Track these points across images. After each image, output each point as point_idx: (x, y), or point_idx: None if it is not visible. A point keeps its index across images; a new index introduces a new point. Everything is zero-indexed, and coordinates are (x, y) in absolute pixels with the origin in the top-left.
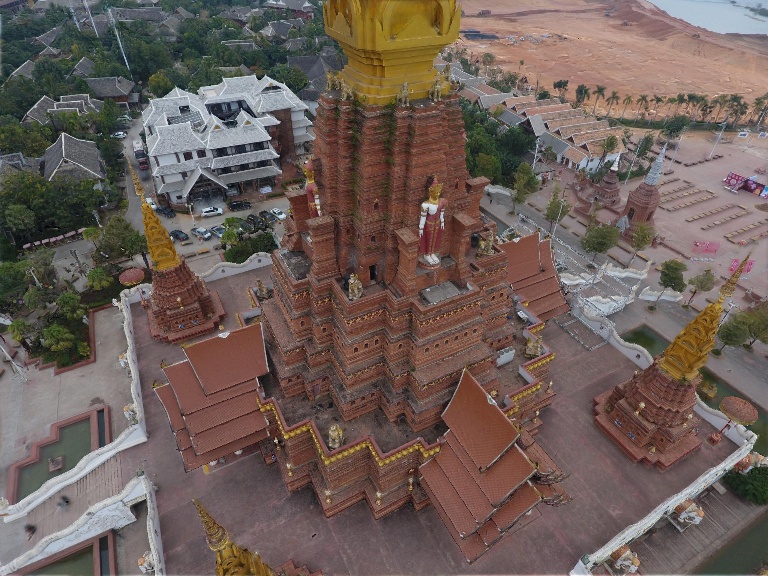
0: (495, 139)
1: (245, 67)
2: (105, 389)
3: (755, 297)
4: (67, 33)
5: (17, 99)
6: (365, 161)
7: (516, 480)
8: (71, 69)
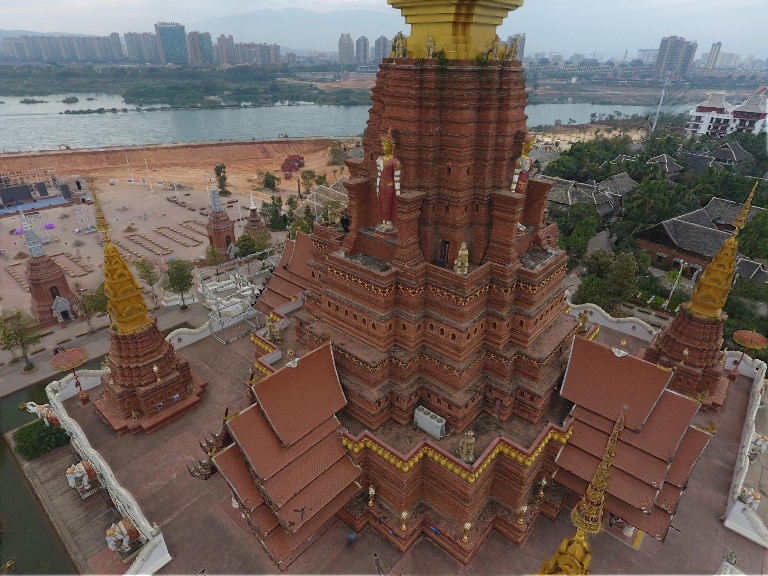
0: None
1: None
2: None
3: None
4: None
5: None
6: None
7: None
8: None
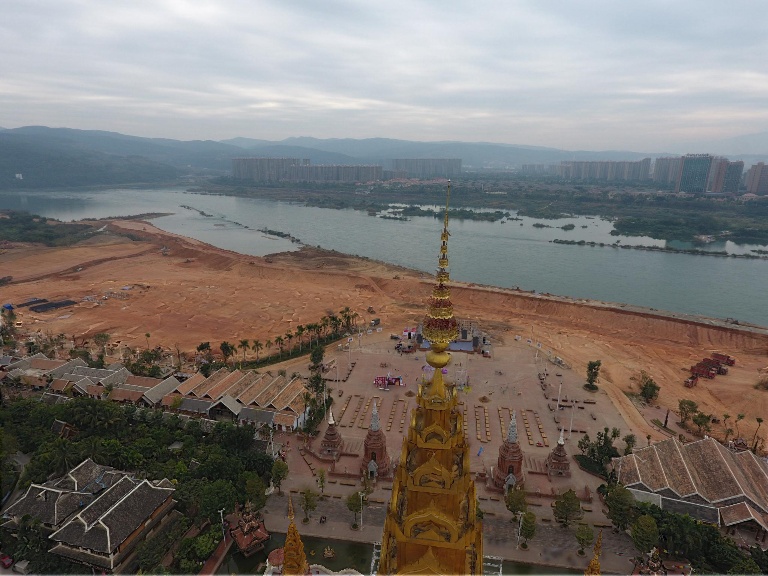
0: (206, 439)
1: None
2: None
3: (479, 475)
4: None
5: None
6: None
7: None
8: None
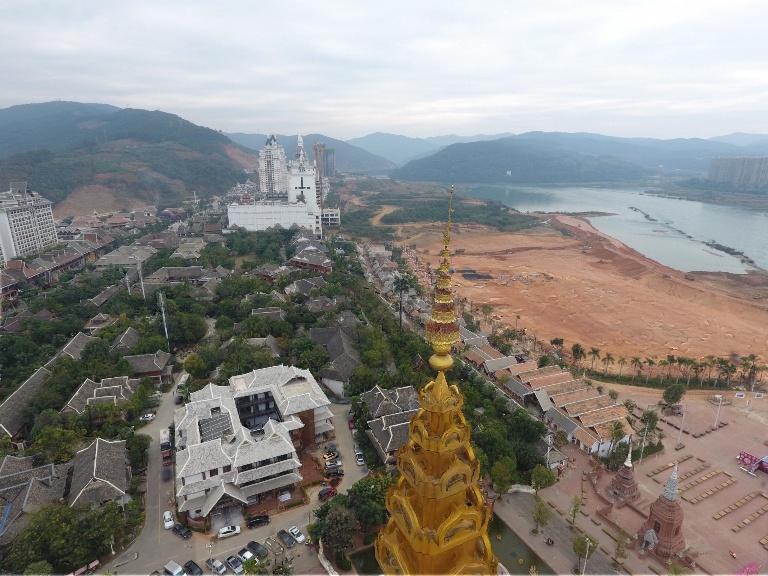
0: (505, 417)
1: (272, 337)
2: None
3: None
4: (118, 297)
5: (62, 387)
6: None
7: None
8: (116, 342)
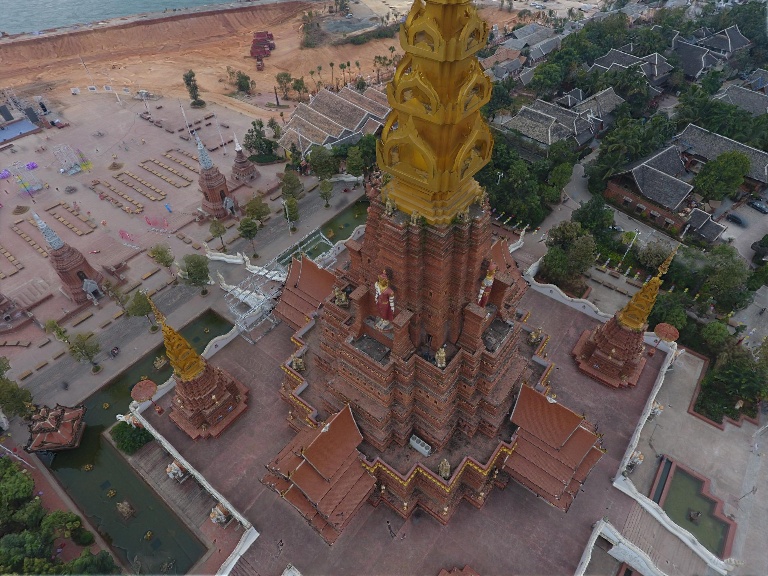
0: None
1: None
2: None
3: None
4: None
5: None
6: None
7: None
8: None
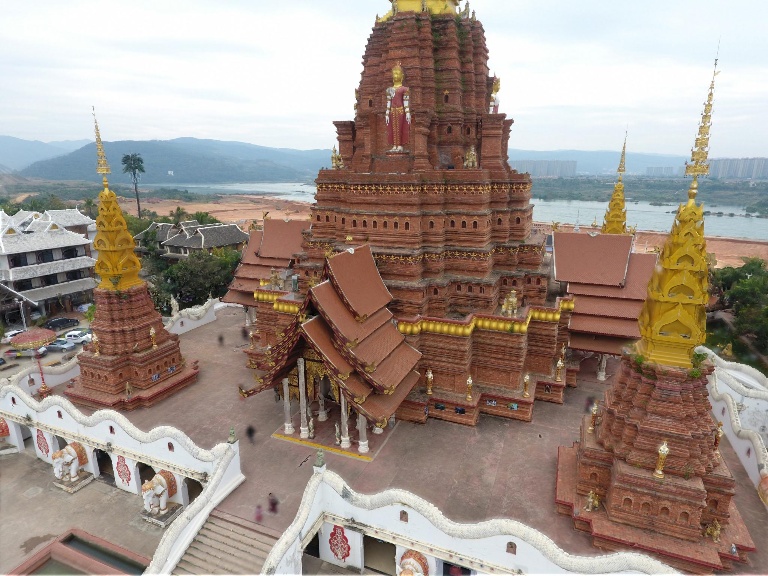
0: None
1: None
2: (36, 523)
3: None
4: None
5: None
6: (454, 55)
7: (650, 273)
8: None
